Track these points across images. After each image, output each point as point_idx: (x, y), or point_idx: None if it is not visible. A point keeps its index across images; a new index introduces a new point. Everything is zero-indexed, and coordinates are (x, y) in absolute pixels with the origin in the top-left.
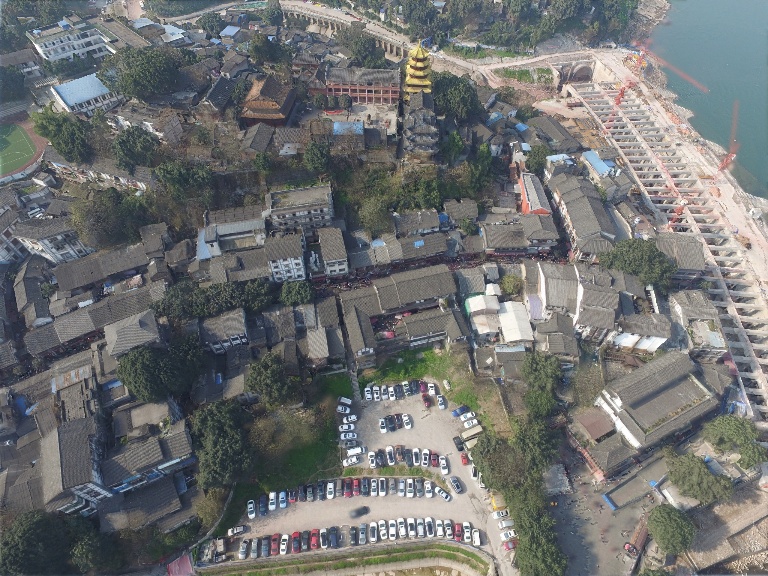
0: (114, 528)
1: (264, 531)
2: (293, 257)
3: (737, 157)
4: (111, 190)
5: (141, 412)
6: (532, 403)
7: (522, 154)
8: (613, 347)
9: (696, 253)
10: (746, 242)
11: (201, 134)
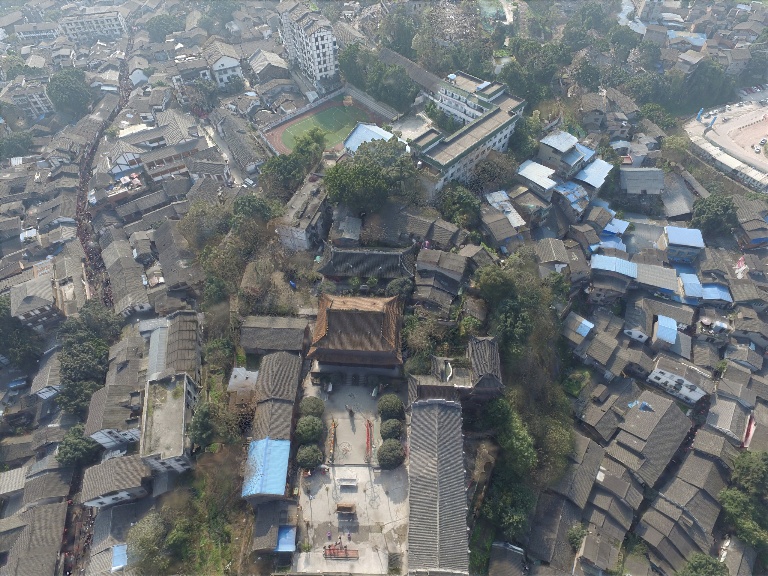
0: None
1: None
2: None
3: None
4: None
5: None
6: None
7: None
8: None
9: None
10: None
11: (256, 267)
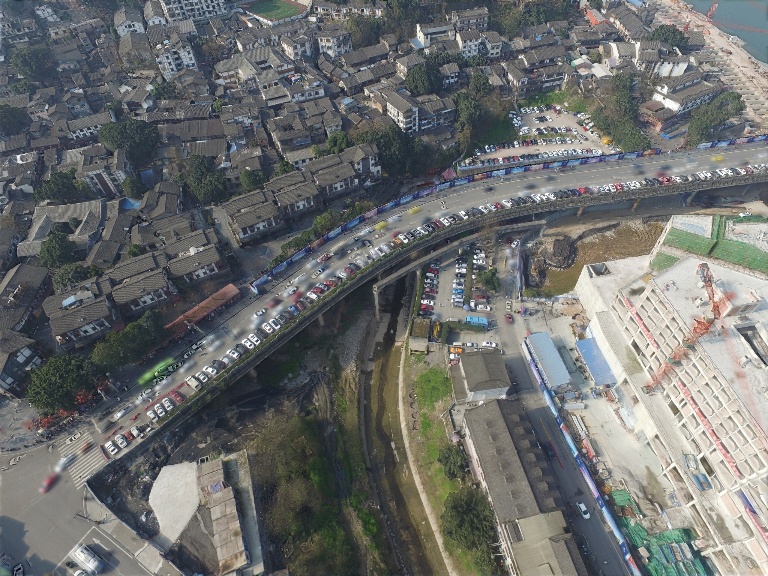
0: (424, 141)
1: (488, 158)
2: (475, 39)
3: (719, 22)
4: (361, 16)
5: (421, 98)
6: (619, 95)
7: (586, 1)
8: (658, 77)
9: (699, 36)
10: (729, 51)
11: None
